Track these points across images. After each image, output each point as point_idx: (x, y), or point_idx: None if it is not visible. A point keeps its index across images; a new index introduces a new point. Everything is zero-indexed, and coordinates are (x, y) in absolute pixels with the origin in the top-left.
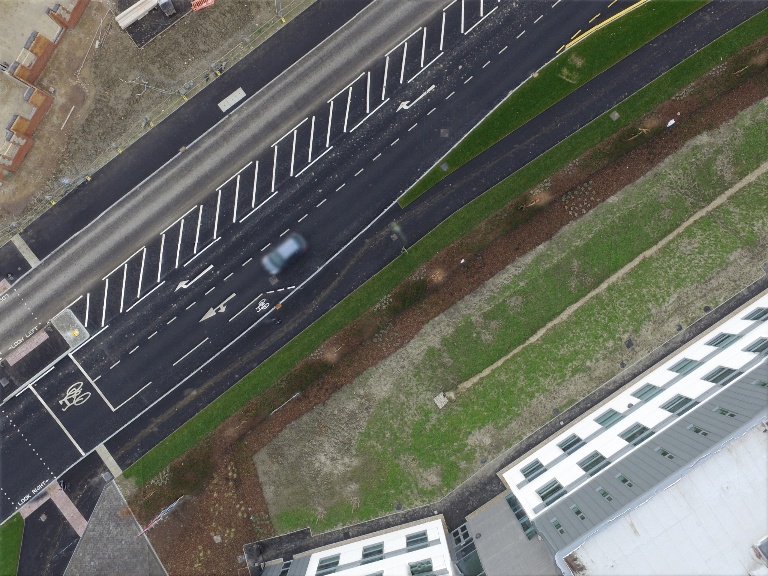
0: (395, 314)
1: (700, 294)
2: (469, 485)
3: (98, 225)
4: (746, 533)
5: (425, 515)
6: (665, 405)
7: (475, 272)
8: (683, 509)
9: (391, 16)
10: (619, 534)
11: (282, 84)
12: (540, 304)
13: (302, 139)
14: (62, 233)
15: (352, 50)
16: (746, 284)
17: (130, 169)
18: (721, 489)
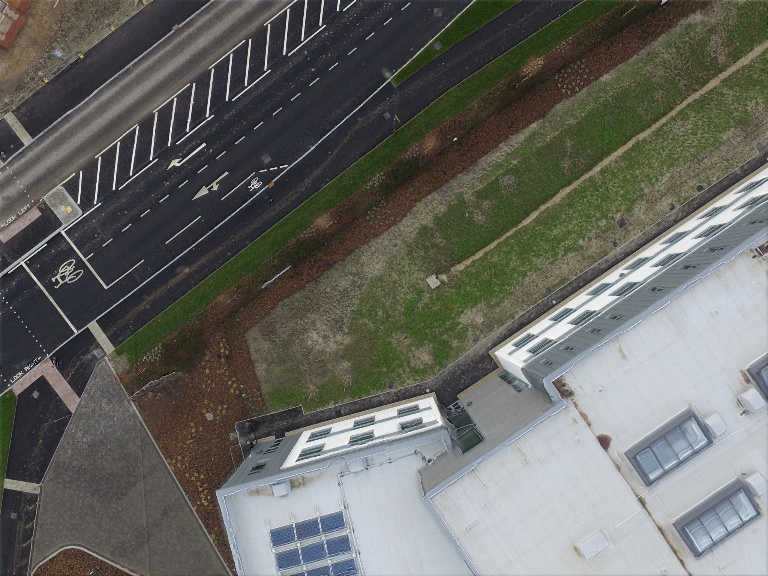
0: (387, 191)
1: (693, 173)
2: (461, 364)
3: (91, 103)
4: (735, 358)
5: (417, 393)
6: (656, 264)
7: (468, 150)
8: (672, 334)
9: None
10: (607, 359)
11: None
12: (533, 185)
13: (295, 18)
14: (55, 111)
15: None
16: (739, 163)
17: (123, 47)
18: (710, 314)
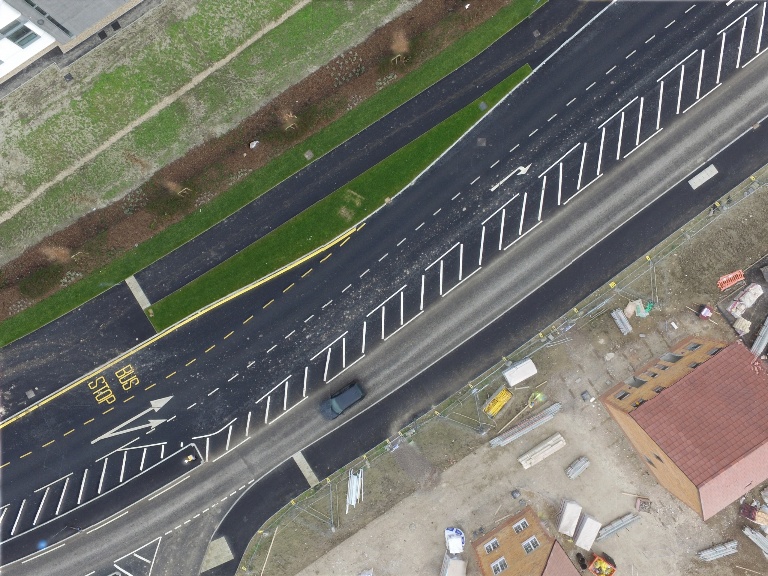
0: None
1: None
2: None
3: None
4: None
5: None
6: None
7: None
8: None
9: (535, 262)
10: None
11: (650, 193)
12: None
13: (630, 136)
14: None
15: (576, 228)
16: None
17: None
18: None
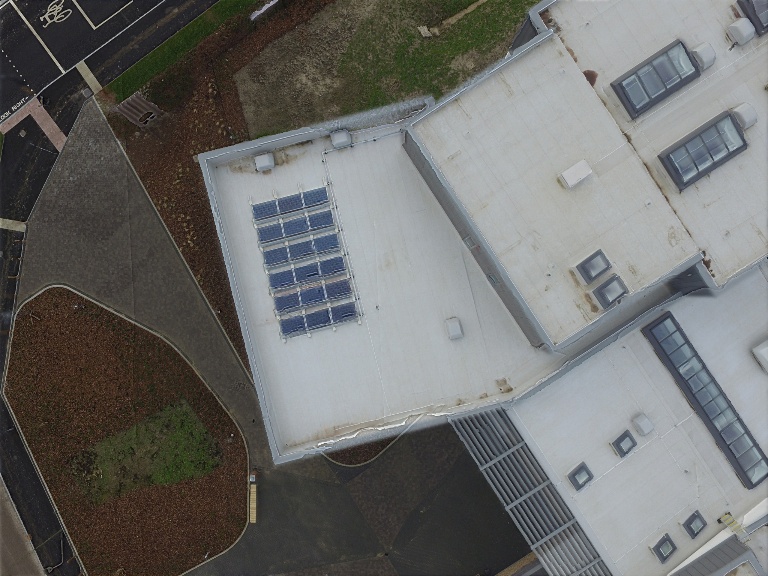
0: None
1: None
2: None
3: None
4: None
5: None
6: None
7: None
8: None
9: None
10: None
11: None
12: None
13: None
14: None
15: None
16: None
17: None
18: None
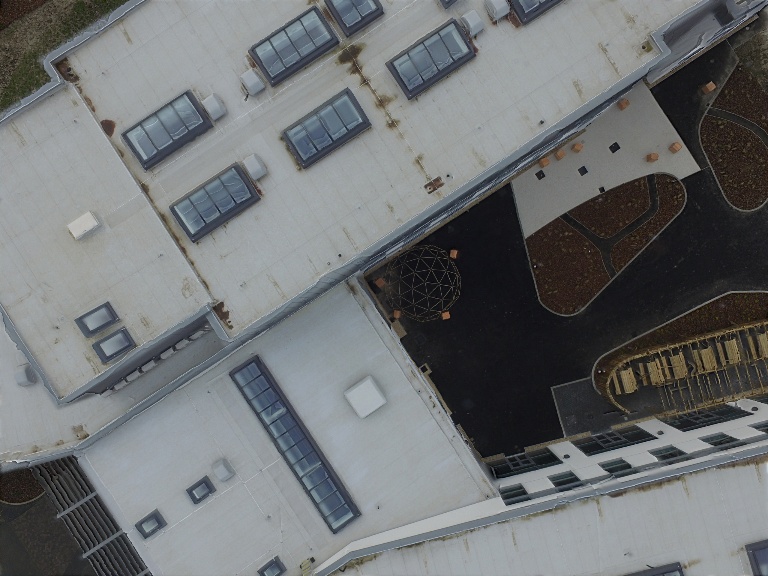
0: None
1: None
2: None
3: None
4: (241, 42)
5: None
6: None
7: None
8: (176, 16)
9: None
10: (112, 43)
11: None
12: None
13: None
14: None
15: None
16: None
17: None
18: None
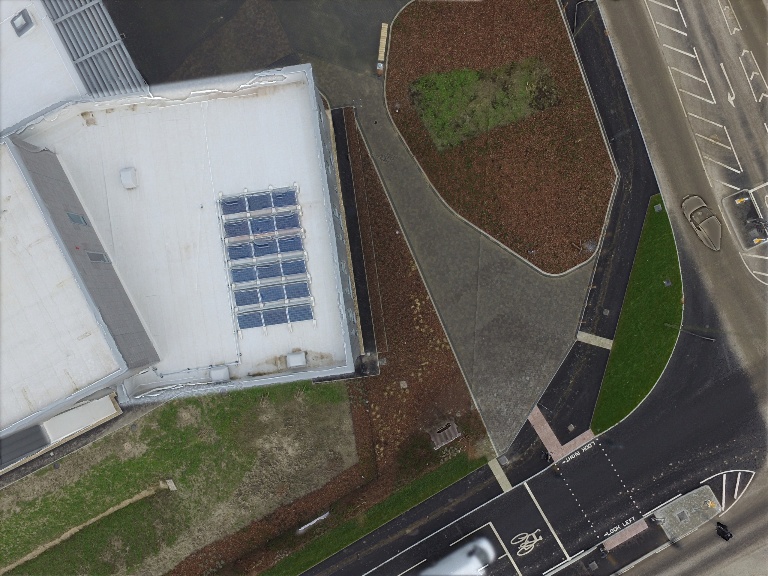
0: None
1: None
2: (151, 405)
3: None
4: None
5: None
6: None
7: None
8: None
9: None
10: None
11: None
12: (61, 569)
13: None
14: None
15: None
16: None
17: None
18: None
